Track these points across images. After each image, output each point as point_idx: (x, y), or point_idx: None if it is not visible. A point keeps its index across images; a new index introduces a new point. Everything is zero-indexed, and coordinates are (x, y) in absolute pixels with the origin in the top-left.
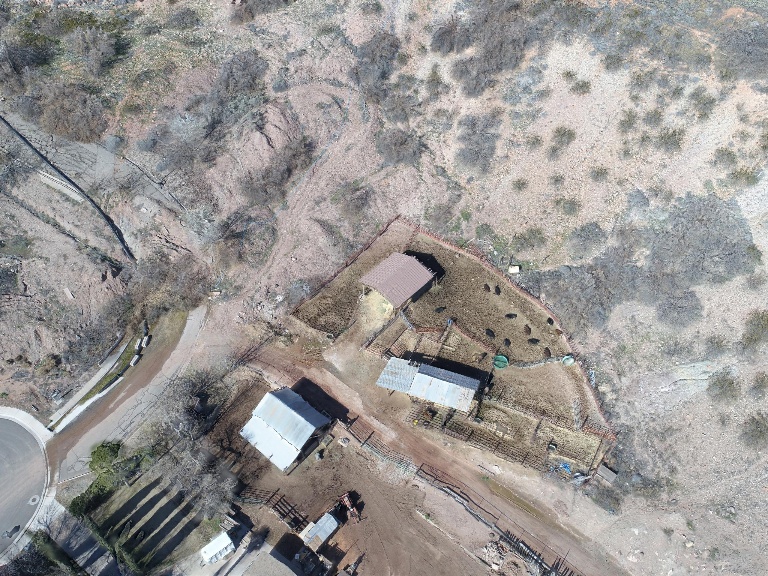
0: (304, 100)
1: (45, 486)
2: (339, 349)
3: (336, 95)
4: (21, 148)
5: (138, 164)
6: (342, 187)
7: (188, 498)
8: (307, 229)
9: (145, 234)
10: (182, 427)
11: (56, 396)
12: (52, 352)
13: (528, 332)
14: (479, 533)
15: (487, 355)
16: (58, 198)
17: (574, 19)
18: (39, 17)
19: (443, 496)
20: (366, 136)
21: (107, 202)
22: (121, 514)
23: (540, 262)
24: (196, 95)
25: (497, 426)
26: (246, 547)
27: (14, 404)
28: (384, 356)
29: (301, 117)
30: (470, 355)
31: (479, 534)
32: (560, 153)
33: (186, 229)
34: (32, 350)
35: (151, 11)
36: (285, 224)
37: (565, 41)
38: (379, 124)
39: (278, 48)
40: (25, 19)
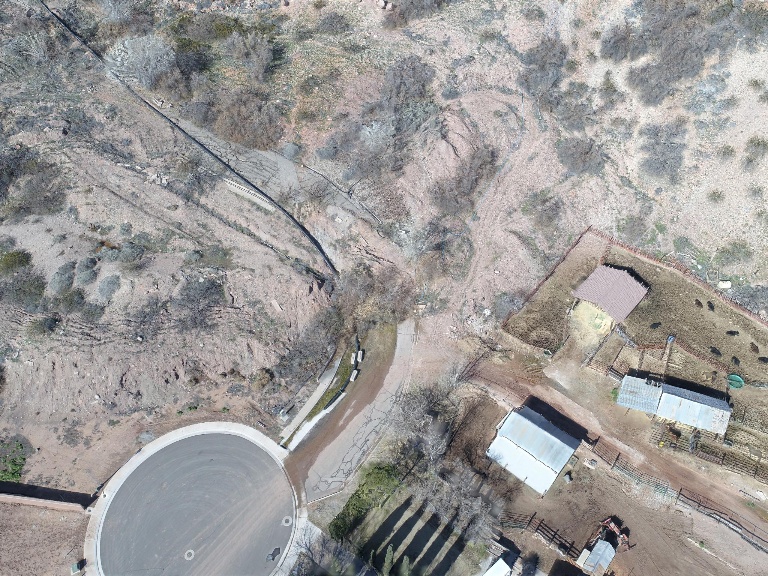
0: (480, 108)
1: (294, 506)
2: (559, 366)
3: (509, 103)
4: (202, 155)
5: (321, 173)
6: (530, 197)
7: (445, 521)
8: (503, 241)
9: (344, 245)
10: (443, 448)
11: (283, 412)
12: (264, 366)
13: (756, 350)
14: (762, 563)
15: (717, 374)
16: (249, 207)
17: (757, 26)
18: (186, 21)
19: (714, 523)
20: (548, 145)
21: (299, 212)
22: (379, 537)
23: (750, 277)
24: (367, 102)
25: (750, 449)
26: (520, 574)
27: (239, 420)
28: (609, 374)
29: (480, 125)
30: (699, 374)
31: (762, 564)
32: (756, 164)
33: (386, 240)
34: (245, 363)
35: (297, 16)
36: (479, 235)
37: (748, 49)
38: (556, 133)
39: (441, 54)
40: (170, 23)
